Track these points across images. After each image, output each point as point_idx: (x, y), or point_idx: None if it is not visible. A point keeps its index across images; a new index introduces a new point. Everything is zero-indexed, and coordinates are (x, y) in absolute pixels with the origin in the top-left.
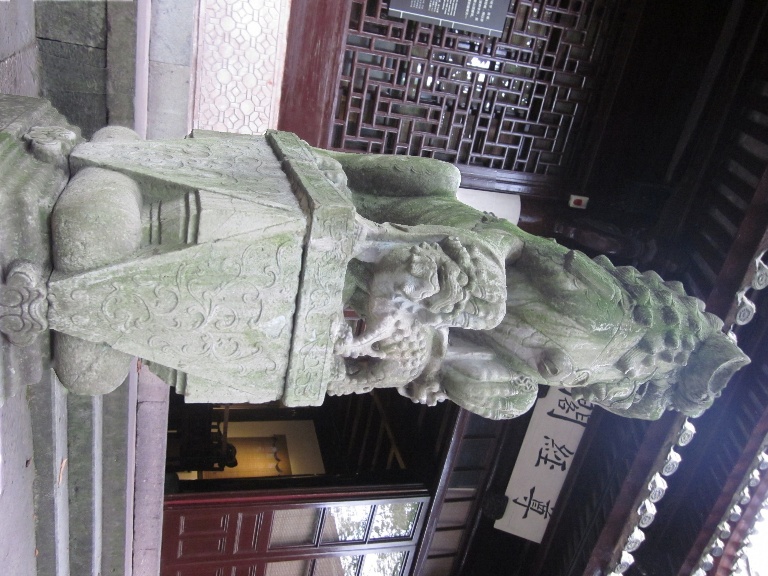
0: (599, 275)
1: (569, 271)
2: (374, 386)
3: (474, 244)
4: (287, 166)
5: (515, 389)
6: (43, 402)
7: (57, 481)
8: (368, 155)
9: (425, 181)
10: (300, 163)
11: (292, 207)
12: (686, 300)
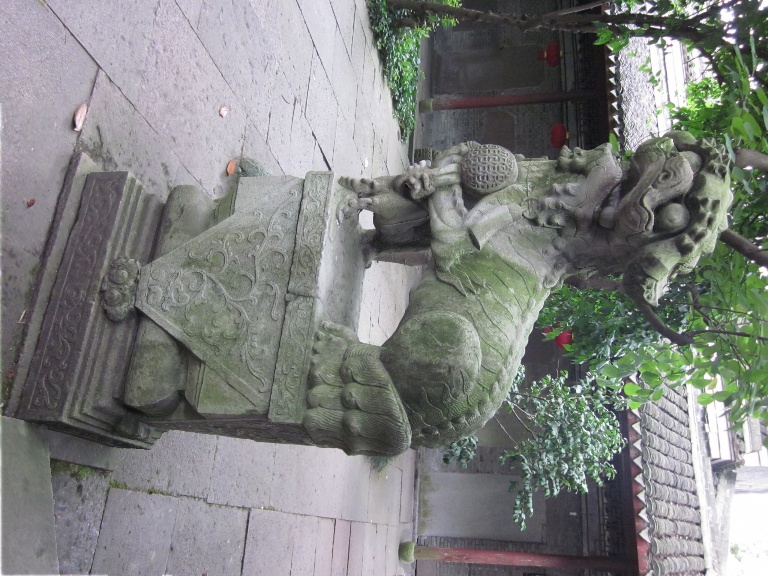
0: None
1: None
2: (376, 178)
3: None
4: None
5: None
6: None
7: None
8: None
9: None
10: None
11: None
12: None
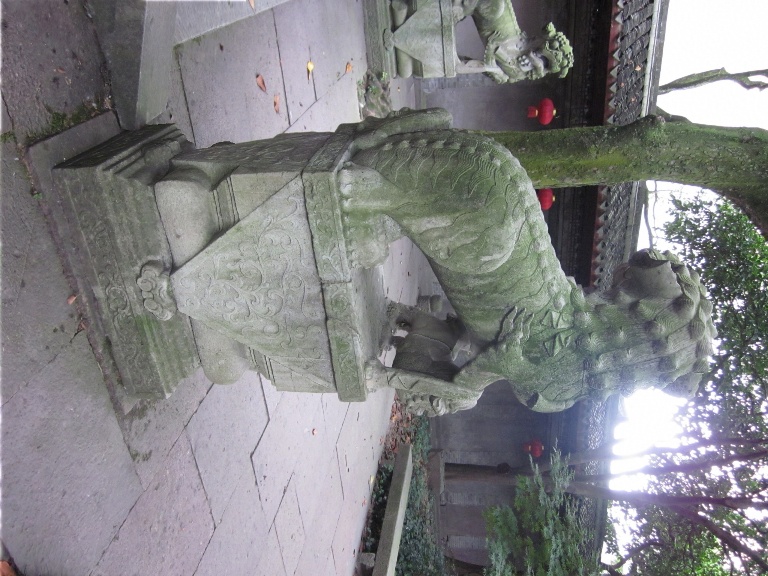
0: None
1: None
2: None
3: None
4: (324, 306)
5: None
6: None
7: None
8: (413, 218)
9: None
10: (334, 299)
11: (328, 385)
12: (663, 381)
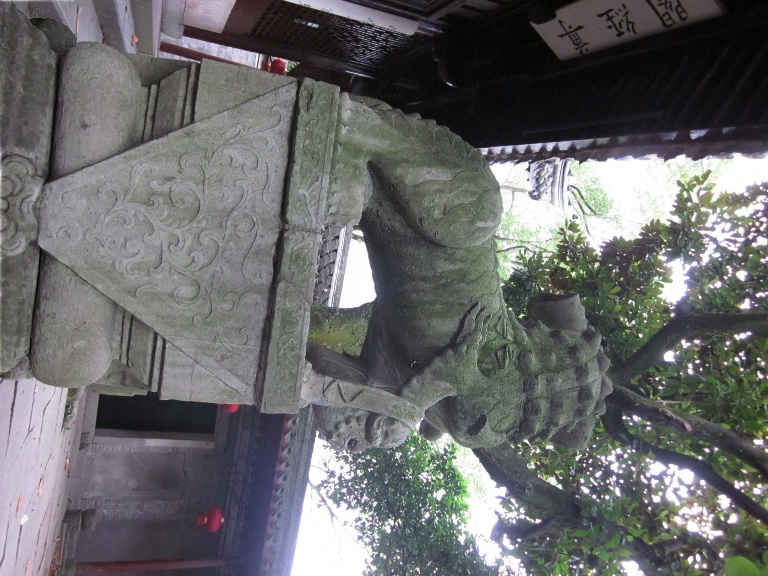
0: (490, 441)
1: (469, 434)
2: None
3: None
4: (278, 262)
5: None
6: (49, 12)
7: None
8: (411, 165)
9: (444, 244)
10: (296, 252)
11: (246, 388)
12: (578, 415)
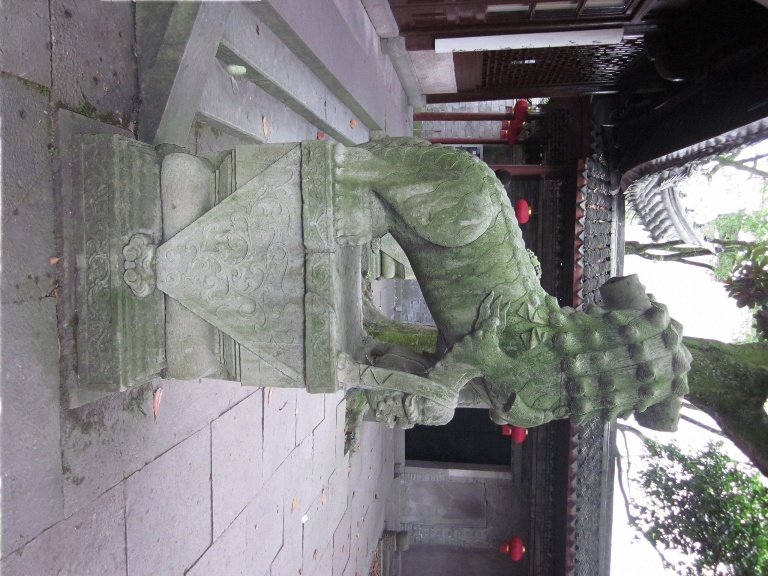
0: (529, 418)
1: None
2: None
3: (428, 398)
4: None
5: (479, 402)
6: (229, 129)
7: (263, 137)
8: (398, 186)
9: (442, 245)
10: (316, 269)
11: (297, 376)
12: (643, 394)
